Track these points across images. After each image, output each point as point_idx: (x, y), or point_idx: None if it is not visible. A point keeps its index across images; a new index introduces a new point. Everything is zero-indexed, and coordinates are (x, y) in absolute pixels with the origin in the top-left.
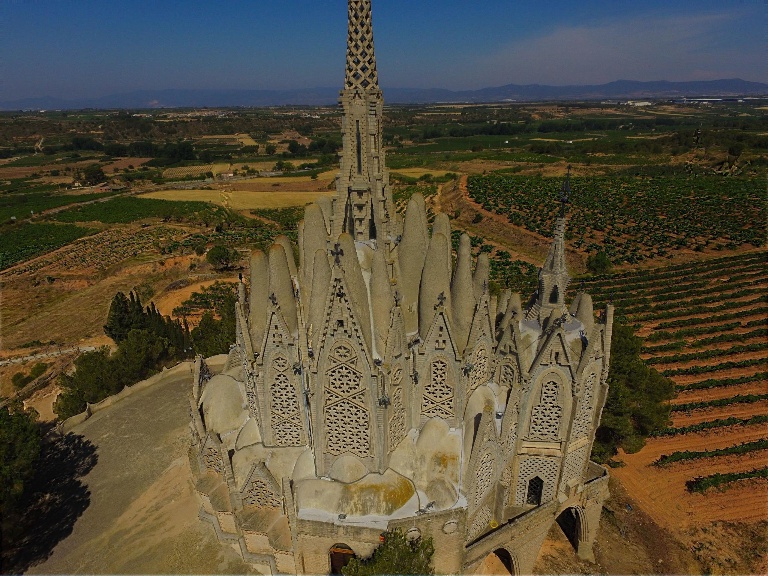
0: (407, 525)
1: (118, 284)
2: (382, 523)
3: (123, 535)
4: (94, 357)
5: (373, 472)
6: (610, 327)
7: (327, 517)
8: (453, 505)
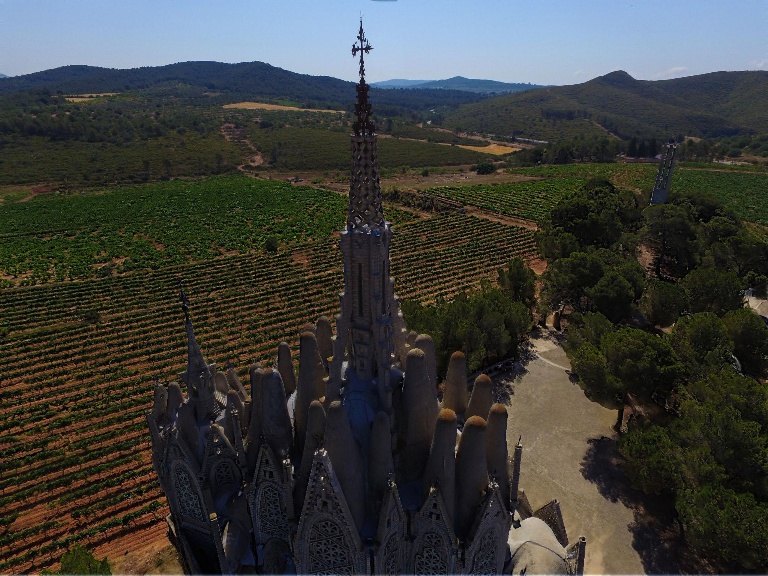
0: None
1: None
2: None
3: None
4: None
5: None
6: None
7: None
8: None
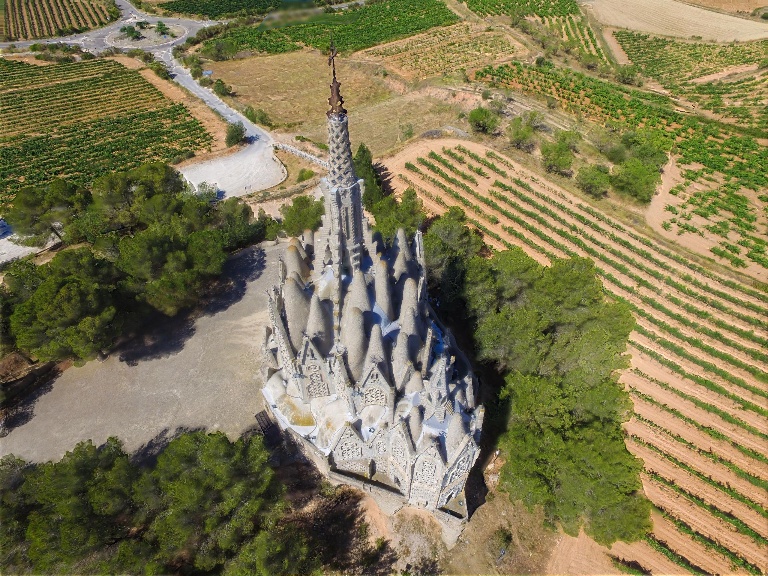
0: (296, 436)
1: (414, 103)
2: (285, 425)
3: (239, 328)
4: (303, 202)
5: (302, 399)
6: (461, 448)
7: (270, 401)
8: (321, 448)
